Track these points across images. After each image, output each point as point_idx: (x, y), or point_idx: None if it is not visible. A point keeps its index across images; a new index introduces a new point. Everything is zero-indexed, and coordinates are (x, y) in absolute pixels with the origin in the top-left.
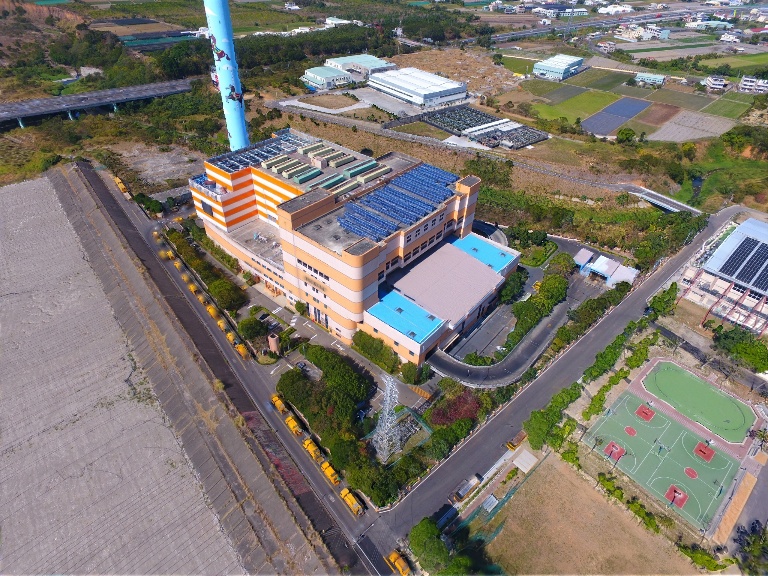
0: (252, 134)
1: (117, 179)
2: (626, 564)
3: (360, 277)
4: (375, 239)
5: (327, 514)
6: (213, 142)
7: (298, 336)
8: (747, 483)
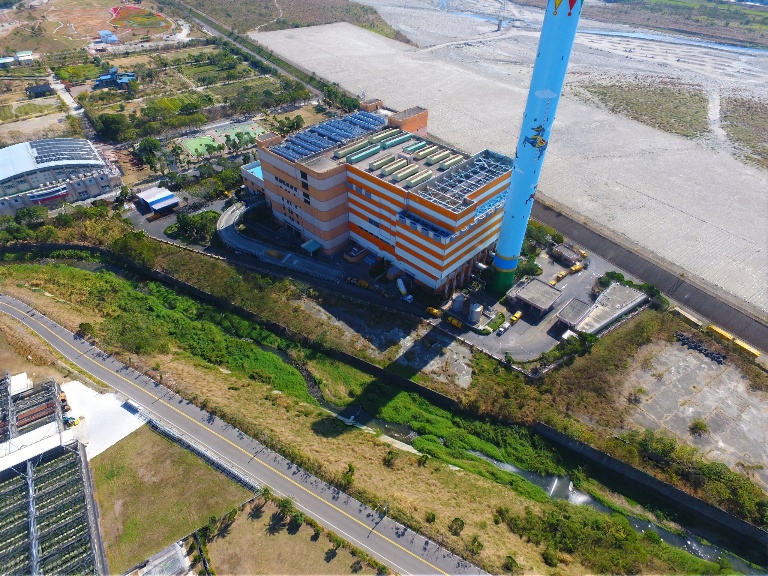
0: (656, 574)
1: (750, 348)
2: None
3: None
4: None
5: None
6: (705, 480)
7: None
8: None
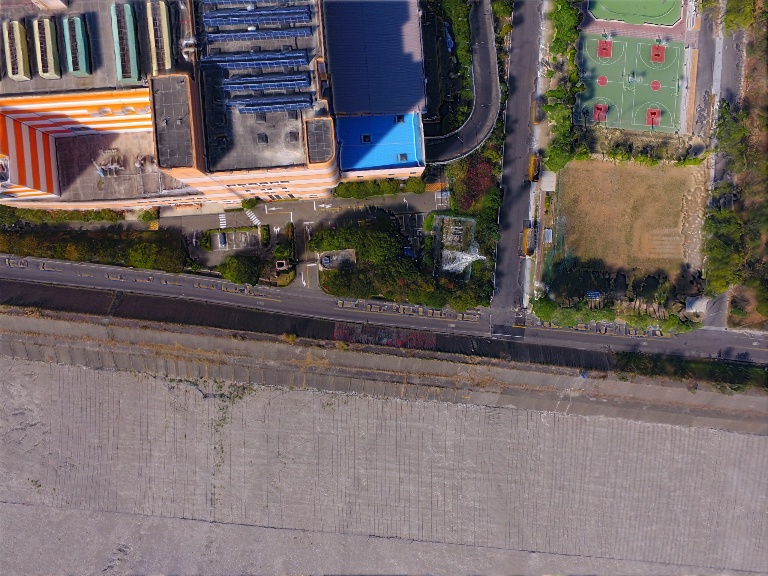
0: None
1: None
2: (644, 201)
3: (335, 165)
4: (308, 105)
5: (460, 337)
6: None
7: (278, 230)
8: (693, 61)
